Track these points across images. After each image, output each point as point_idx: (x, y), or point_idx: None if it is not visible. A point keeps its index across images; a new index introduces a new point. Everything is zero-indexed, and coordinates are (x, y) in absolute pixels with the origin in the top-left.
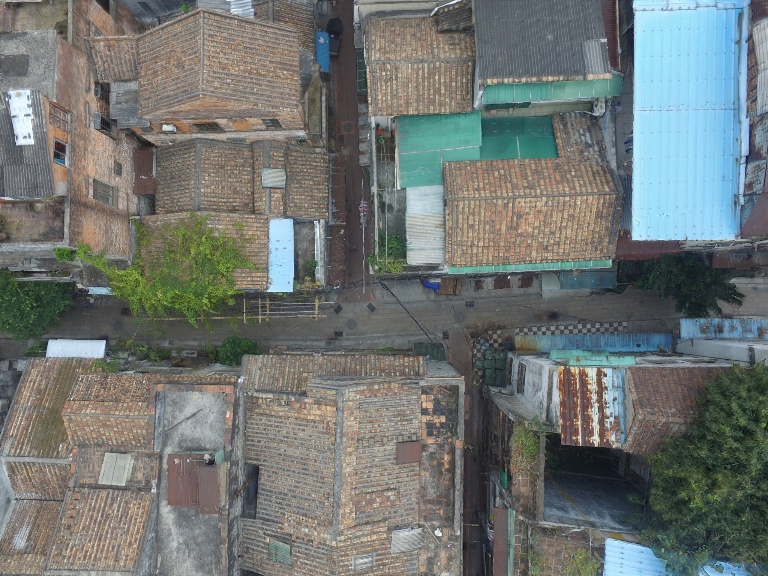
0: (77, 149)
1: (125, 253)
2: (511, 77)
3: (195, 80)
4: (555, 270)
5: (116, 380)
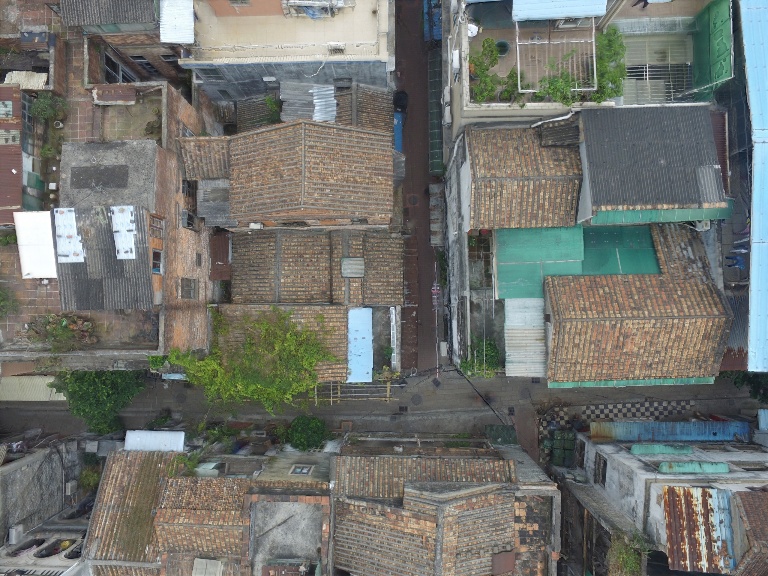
0: (170, 253)
1: (203, 343)
2: (625, 204)
3: (295, 192)
4: None
5: (206, 485)
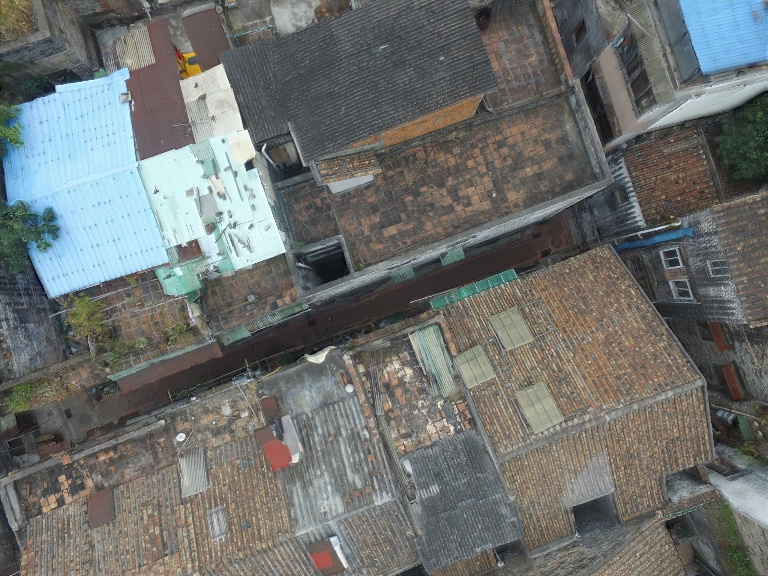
0: None
1: None
2: None
3: None
4: None
5: None
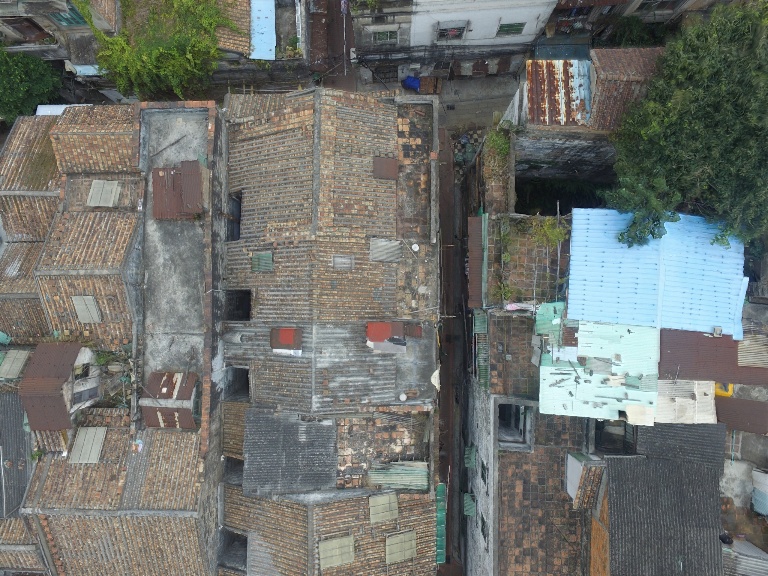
0: None
1: (111, 22)
2: None
3: None
4: (530, 44)
5: (102, 110)
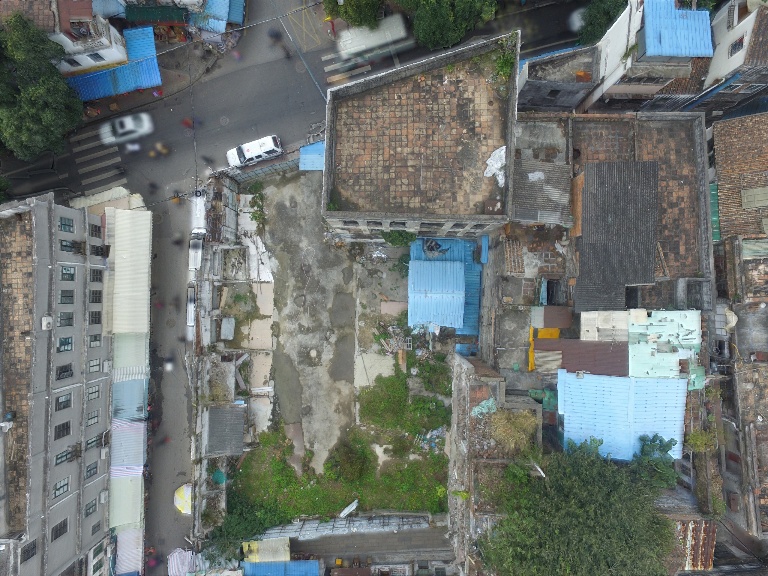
0: None
1: None
2: None
3: None
4: None
5: None
